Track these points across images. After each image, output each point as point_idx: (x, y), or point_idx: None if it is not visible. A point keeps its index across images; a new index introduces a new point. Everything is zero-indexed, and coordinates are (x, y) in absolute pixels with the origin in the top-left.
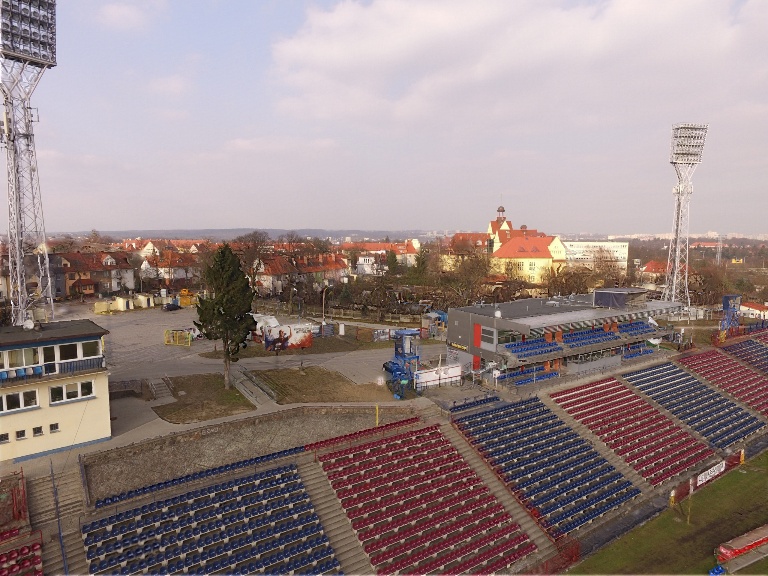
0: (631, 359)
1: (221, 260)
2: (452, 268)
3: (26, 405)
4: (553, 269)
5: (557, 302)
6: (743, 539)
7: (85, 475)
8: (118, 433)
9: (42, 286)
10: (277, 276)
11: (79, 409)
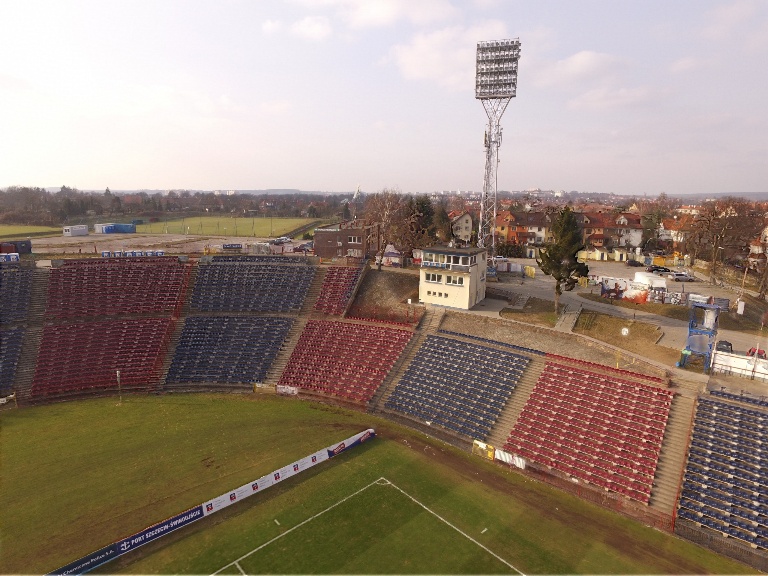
0: None
1: (561, 219)
2: None
3: (438, 281)
4: None
5: None
6: None
7: (443, 318)
8: (473, 310)
9: None
10: None
11: (456, 290)
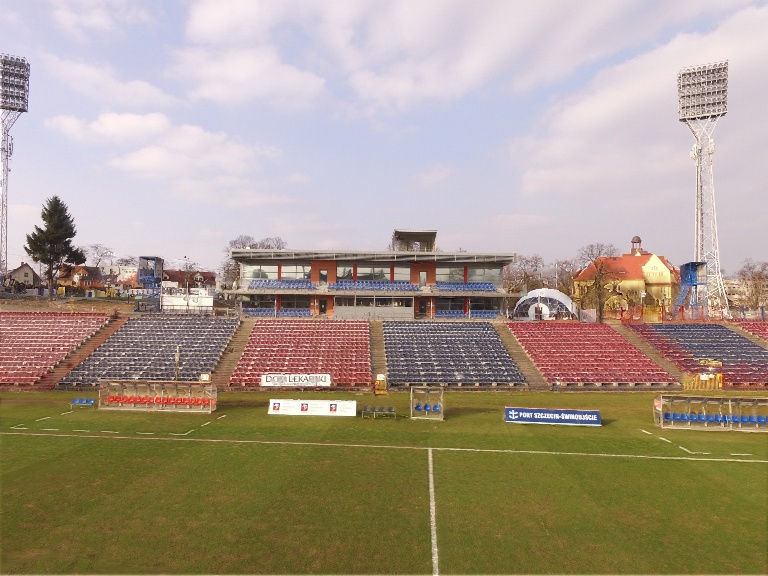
0: None
1: None
2: None
3: None
4: (650, 294)
5: None
6: None
7: None
8: None
9: None
10: None
11: None
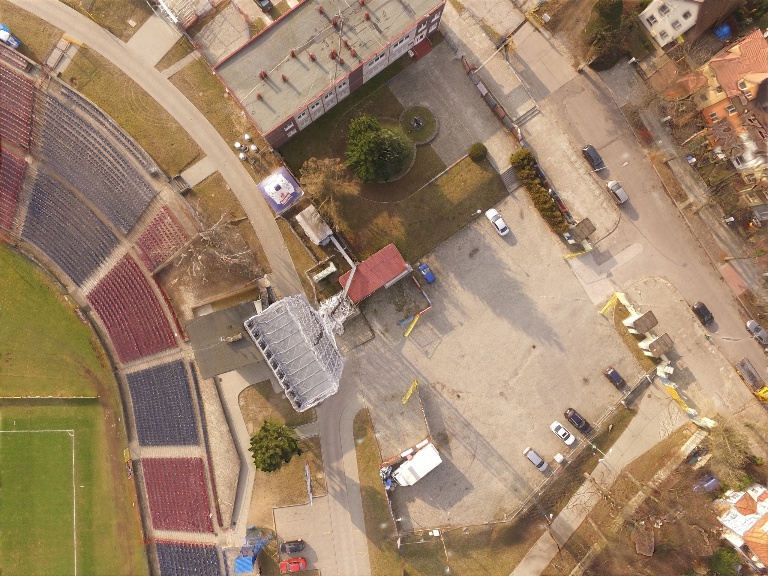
0: None
1: None
2: None
3: None
4: None
5: None
6: None
7: None
8: None
9: (767, 205)
10: None
11: None
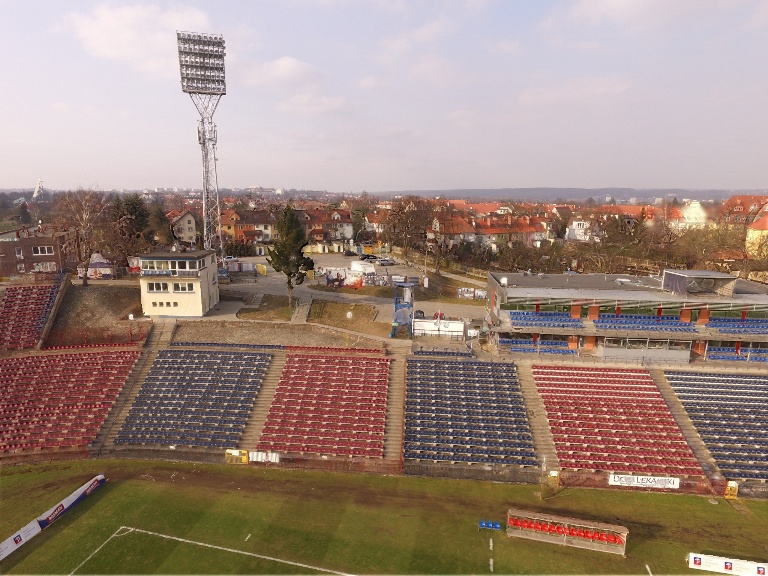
0: (722, 361)
1: (285, 218)
2: (671, 239)
3: (163, 290)
4: None
5: (627, 280)
6: (533, 513)
7: (175, 330)
8: (208, 316)
9: None
10: (450, 235)
11: (187, 297)
